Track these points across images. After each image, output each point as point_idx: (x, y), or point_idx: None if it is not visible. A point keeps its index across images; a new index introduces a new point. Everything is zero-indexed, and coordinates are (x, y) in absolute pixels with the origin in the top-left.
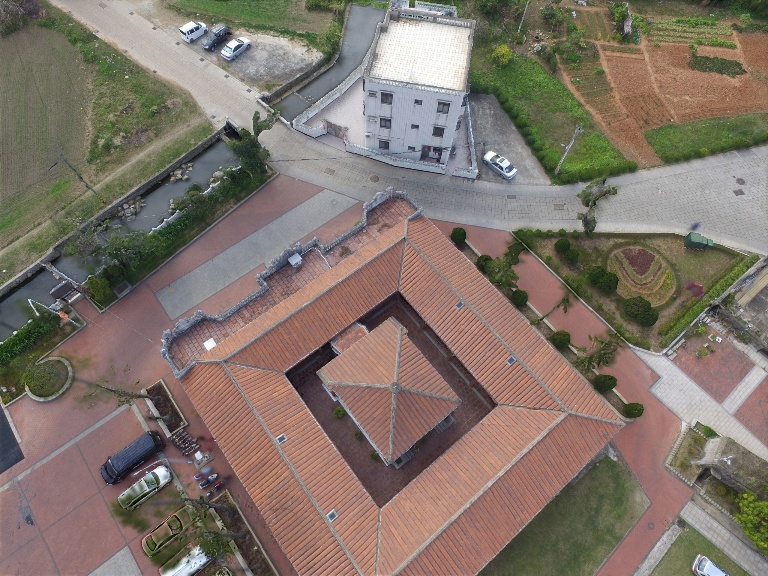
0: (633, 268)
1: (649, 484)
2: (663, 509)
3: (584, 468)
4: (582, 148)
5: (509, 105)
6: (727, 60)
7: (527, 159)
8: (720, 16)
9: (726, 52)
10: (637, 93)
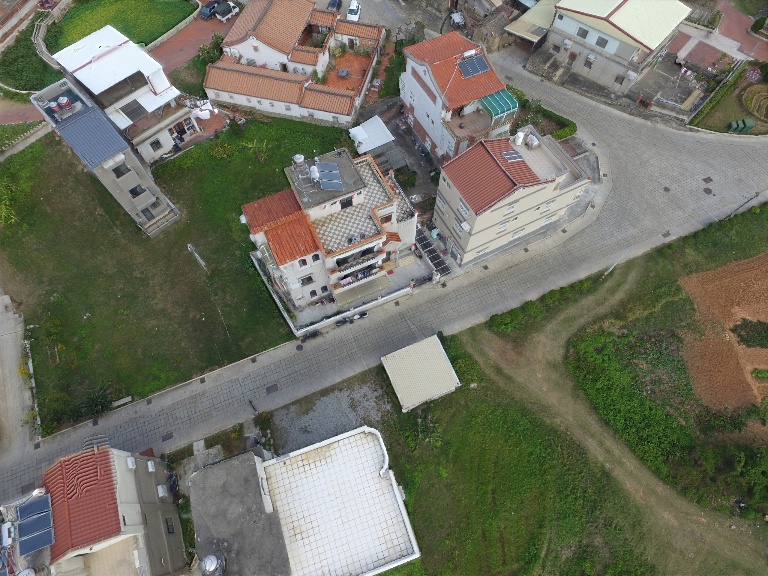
0: None
1: (729, 8)
2: (719, 1)
3: (764, 11)
4: None
5: None
6: (760, 346)
7: None
8: None
9: (763, 362)
10: None
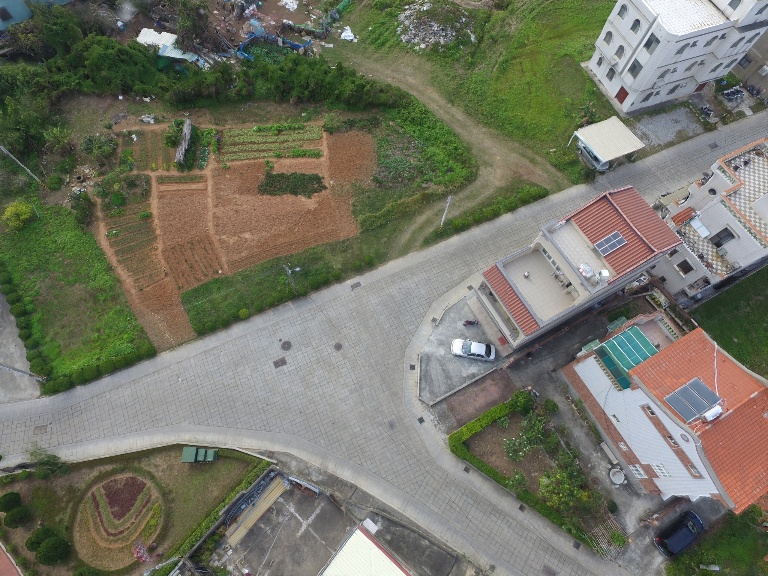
0: (111, 510)
1: None
2: None
3: None
4: (93, 334)
5: (4, 289)
6: (306, 175)
7: (17, 363)
8: (313, 115)
9: (308, 163)
10: (186, 239)
